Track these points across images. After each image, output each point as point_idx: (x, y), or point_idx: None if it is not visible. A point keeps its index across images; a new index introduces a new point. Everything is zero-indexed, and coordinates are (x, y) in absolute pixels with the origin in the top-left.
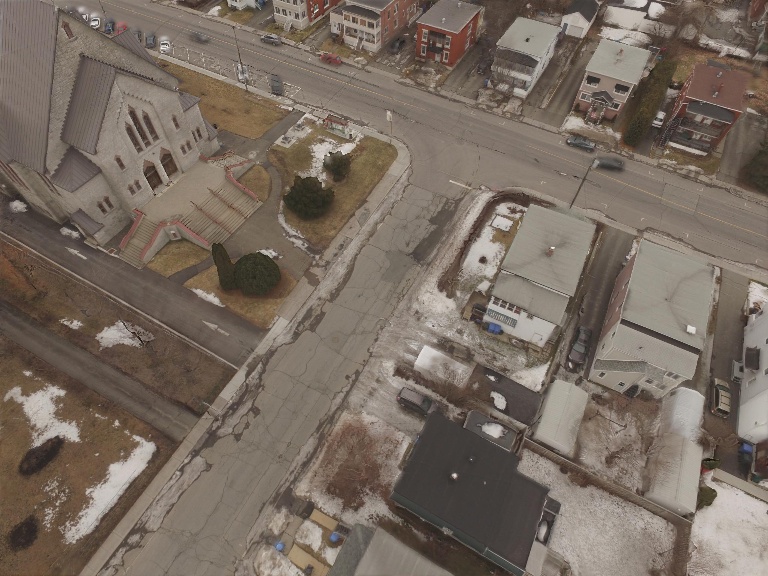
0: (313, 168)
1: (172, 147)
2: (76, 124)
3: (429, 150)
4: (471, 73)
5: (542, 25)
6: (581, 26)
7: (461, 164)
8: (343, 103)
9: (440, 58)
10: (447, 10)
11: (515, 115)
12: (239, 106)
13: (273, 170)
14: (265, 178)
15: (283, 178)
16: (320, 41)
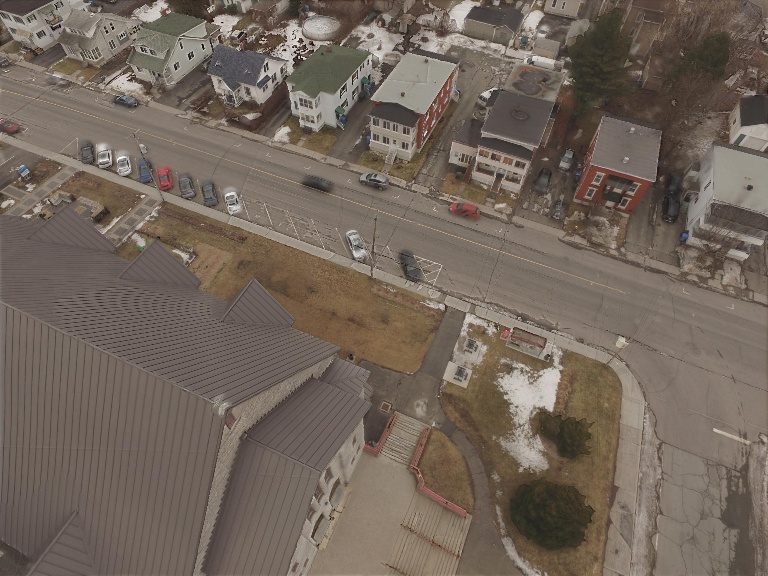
0: (517, 428)
1: (343, 471)
2: (233, 551)
3: (660, 370)
4: (654, 220)
5: (751, 158)
6: (765, 138)
7: (714, 394)
8: (509, 289)
9: (614, 203)
10: (618, 139)
11: (740, 290)
12: (370, 309)
13: (461, 439)
14: (456, 458)
15: (482, 455)
16: (439, 178)
